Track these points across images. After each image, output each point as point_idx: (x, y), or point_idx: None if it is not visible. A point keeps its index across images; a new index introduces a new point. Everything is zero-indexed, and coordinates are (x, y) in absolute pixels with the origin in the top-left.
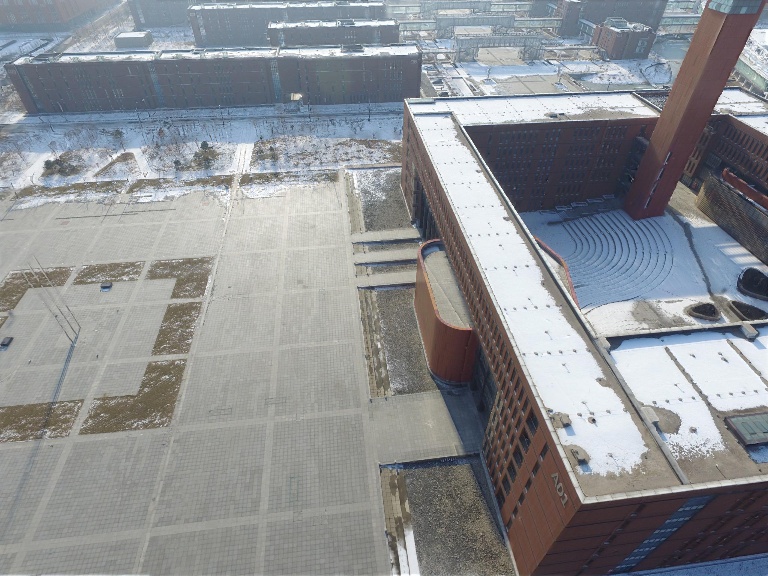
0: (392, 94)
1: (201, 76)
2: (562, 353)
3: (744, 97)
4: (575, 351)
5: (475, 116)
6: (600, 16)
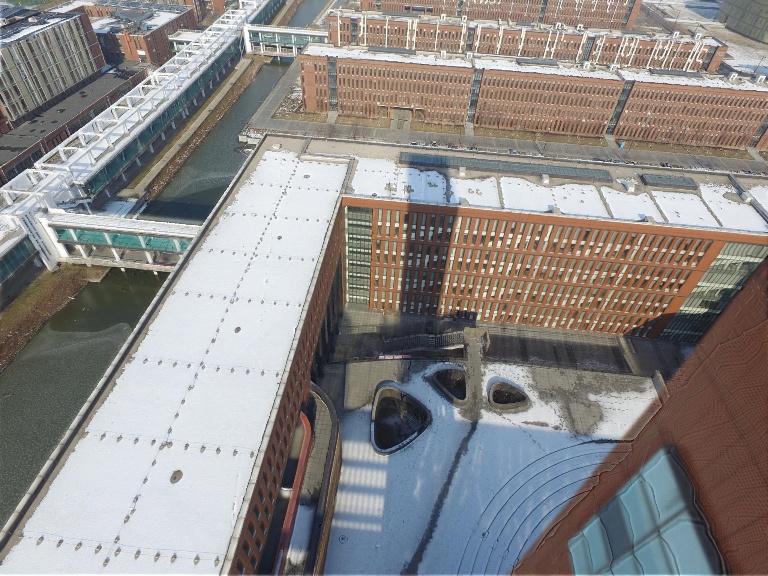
0: None
1: None
2: None
3: None
4: None
5: None
6: None
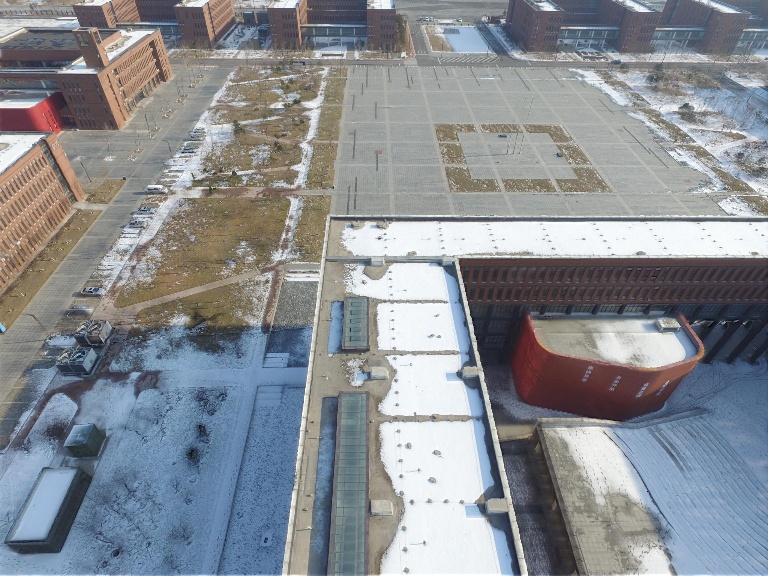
0: None
1: None
2: (441, 241)
3: None
4: (443, 248)
5: None
6: None
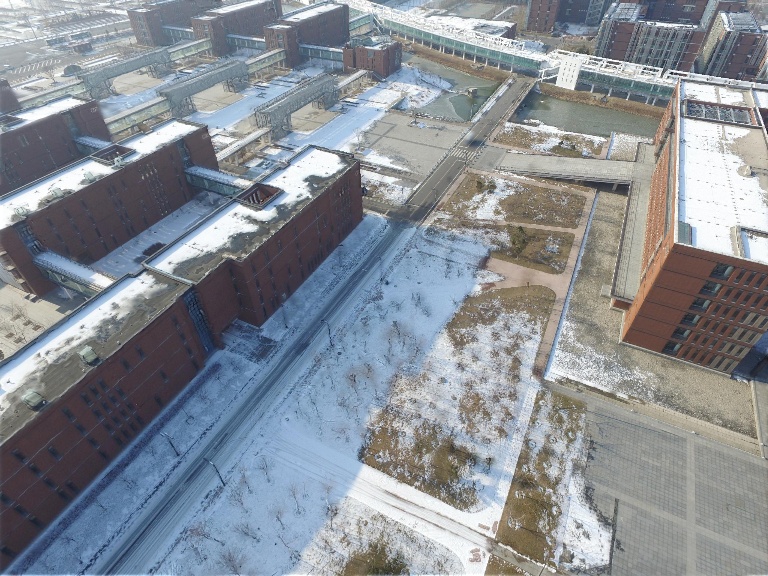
0: (344, 228)
1: (56, 442)
2: None
3: (703, 87)
4: None
5: (746, 217)
6: (312, 36)
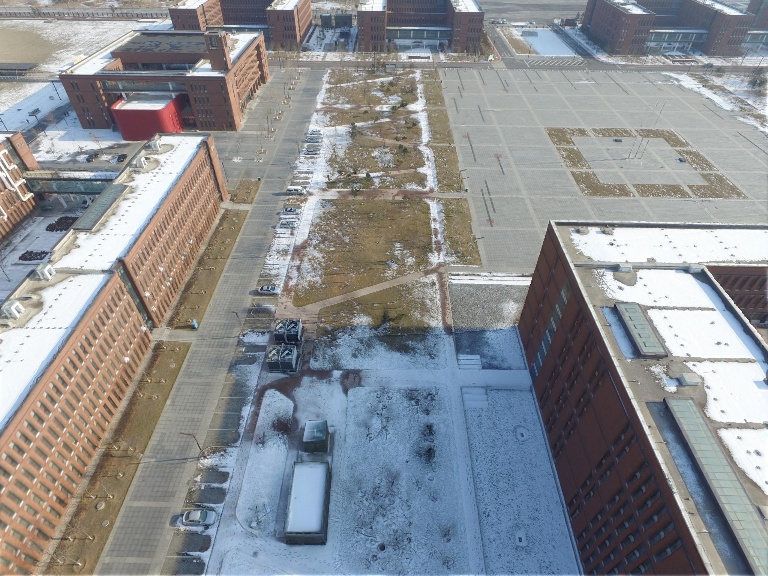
0: None
1: None
2: (674, 248)
3: None
4: (680, 255)
5: None
6: None
